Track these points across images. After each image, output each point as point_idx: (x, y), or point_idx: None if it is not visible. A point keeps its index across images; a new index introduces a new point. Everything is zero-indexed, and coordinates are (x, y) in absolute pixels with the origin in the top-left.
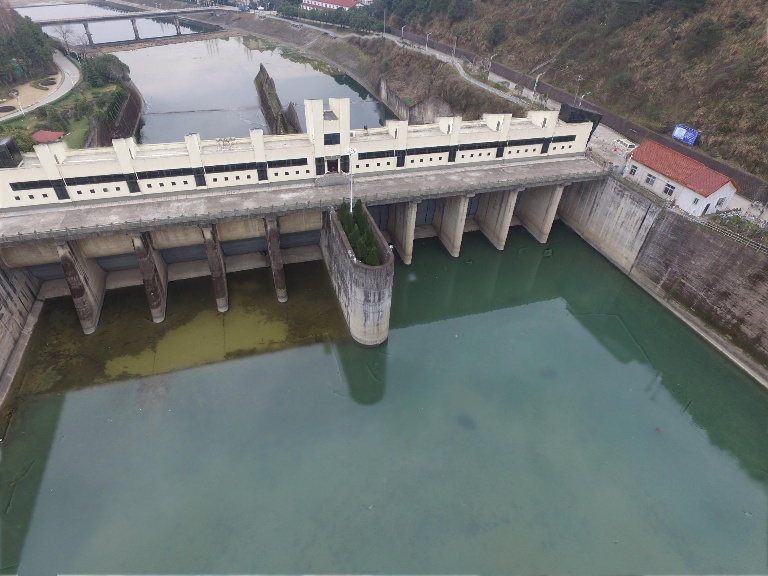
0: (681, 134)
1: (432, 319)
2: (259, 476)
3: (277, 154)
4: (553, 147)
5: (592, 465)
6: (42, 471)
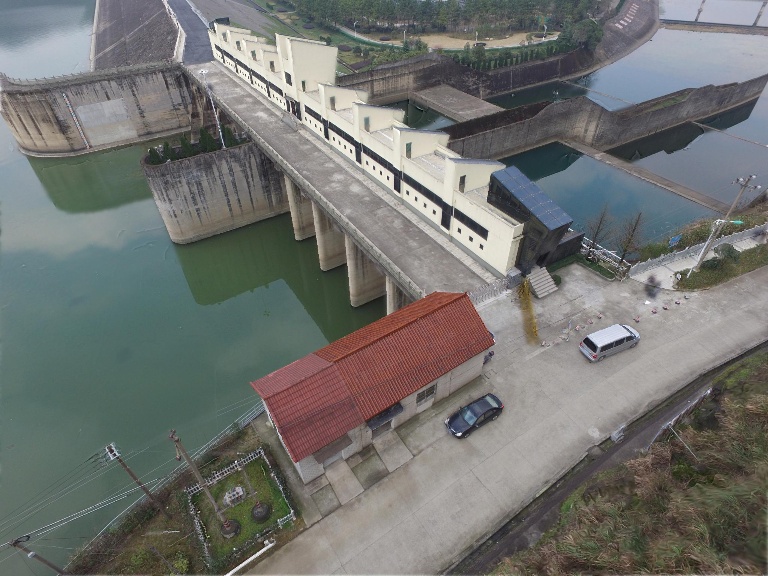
0: None
1: (320, 323)
2: (66, 222)
3: (271, 77)
4: (458, 227)
5: None
6: (92, 164)
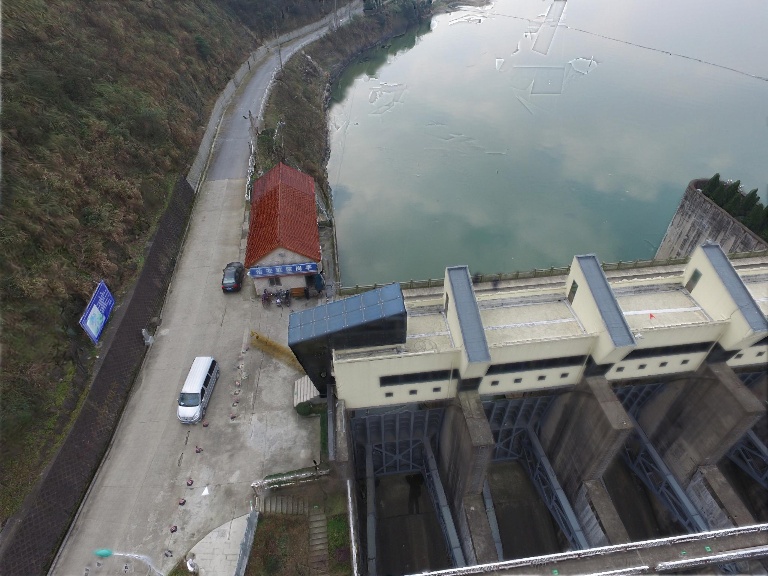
0: (99, 319)
1: None
2: None
3: None
4: None
5: (492, 194)
6: None
